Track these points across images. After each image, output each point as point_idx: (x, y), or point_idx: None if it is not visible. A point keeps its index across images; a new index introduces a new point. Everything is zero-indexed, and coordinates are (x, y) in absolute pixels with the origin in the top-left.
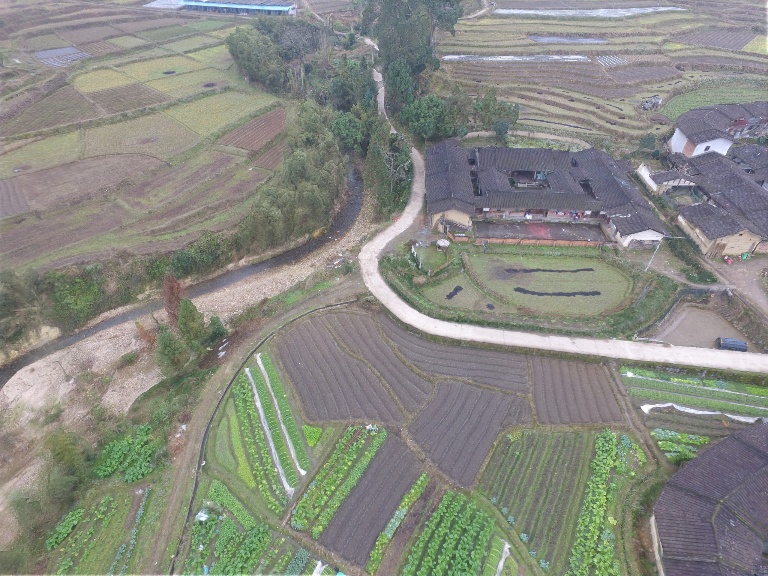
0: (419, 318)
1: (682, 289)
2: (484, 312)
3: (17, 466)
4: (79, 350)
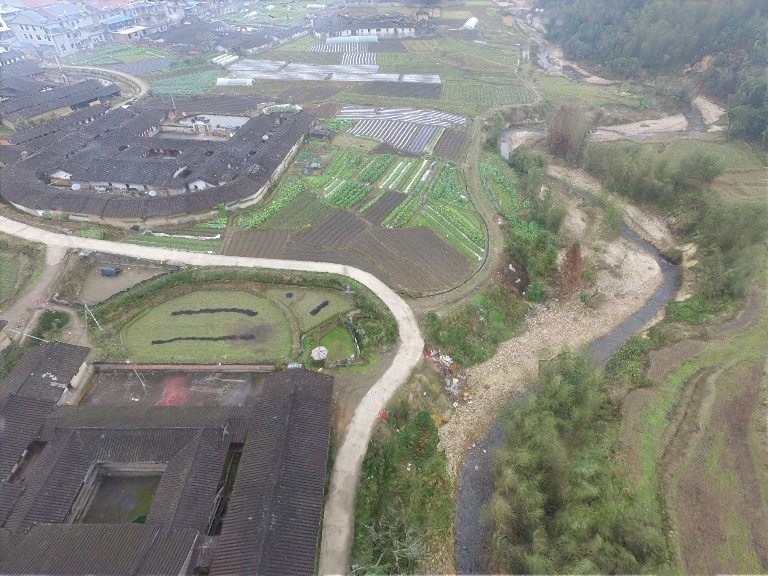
0: (357, 276)
1: (91, 307)
2: (300, 277)
3: (589, 233)
4: (635, 282)
